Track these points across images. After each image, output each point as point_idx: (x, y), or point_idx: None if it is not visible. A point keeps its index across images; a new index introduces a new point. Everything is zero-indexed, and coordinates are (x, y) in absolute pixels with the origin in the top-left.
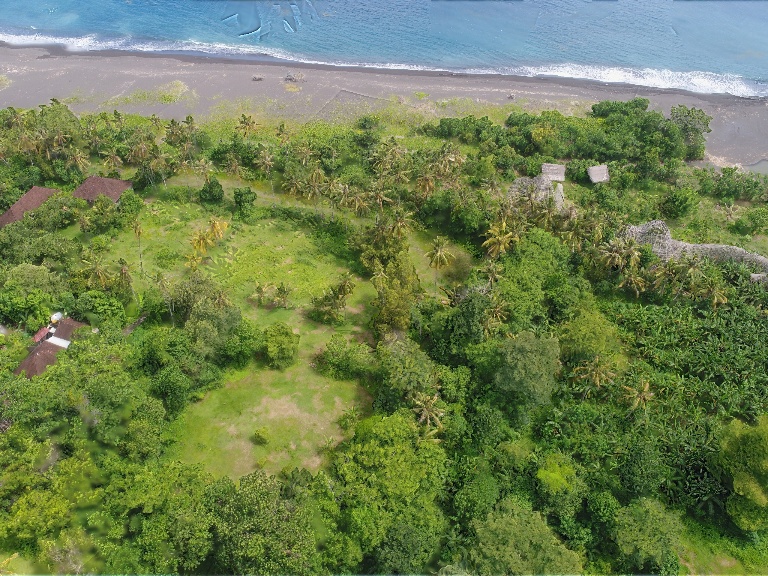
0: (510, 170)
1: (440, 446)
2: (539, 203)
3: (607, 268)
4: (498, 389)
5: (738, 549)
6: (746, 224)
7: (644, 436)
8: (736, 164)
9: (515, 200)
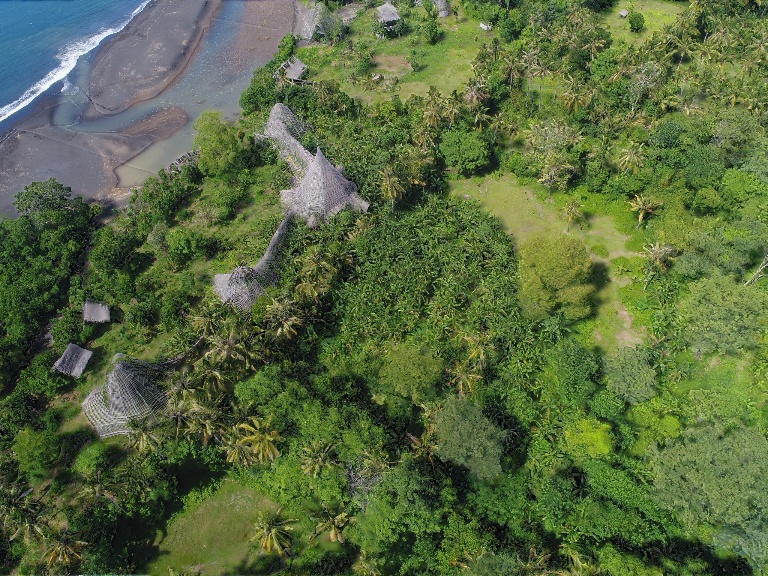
0: (40, 416)
1: (547, 566)
2: (193, 379)
3: (285, 339)
4: (473, 485)
5: (588, 326)
6: (227, 211)
7: (503, 360)
8: (112, 191)
9: (178, 408)
